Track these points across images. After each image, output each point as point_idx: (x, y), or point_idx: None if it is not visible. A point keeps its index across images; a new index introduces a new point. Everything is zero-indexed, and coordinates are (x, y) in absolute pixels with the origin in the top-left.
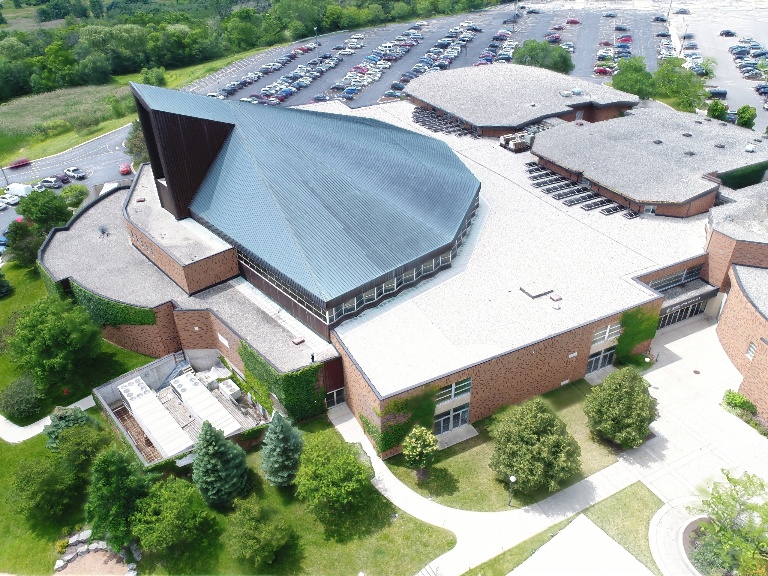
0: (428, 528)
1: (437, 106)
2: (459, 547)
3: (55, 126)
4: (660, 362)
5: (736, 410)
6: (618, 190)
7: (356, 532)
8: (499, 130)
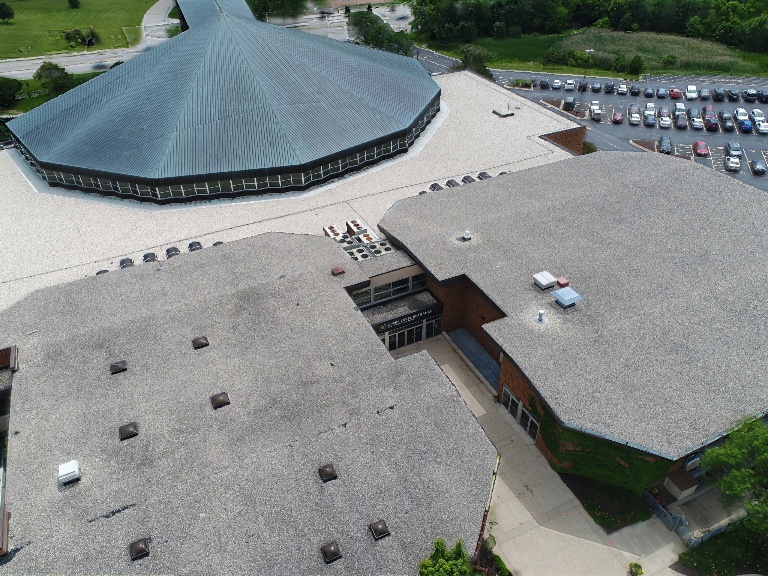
0: None
1: None
2: None
3: (579, 58)
4: None
5: None
6: (81, 279)
7: None
8: None
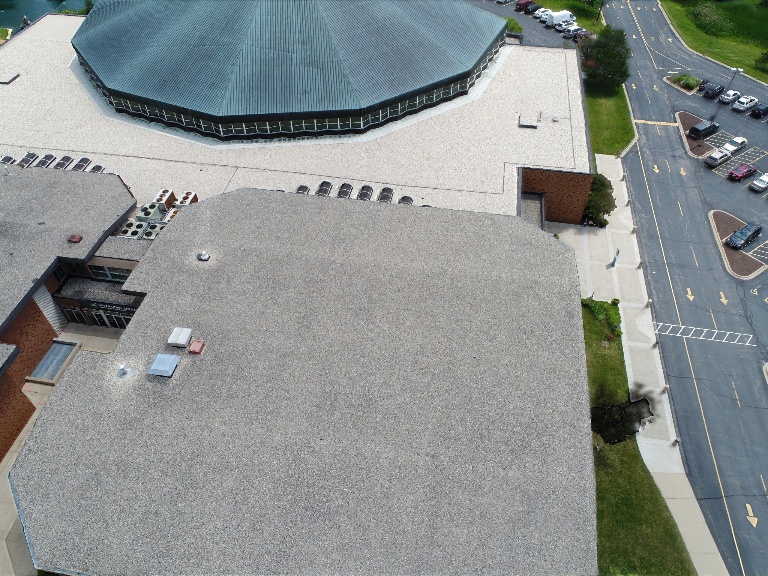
0: None
1: None
2: None
3: None
4: None
5: None
6: None
7: None
8: None
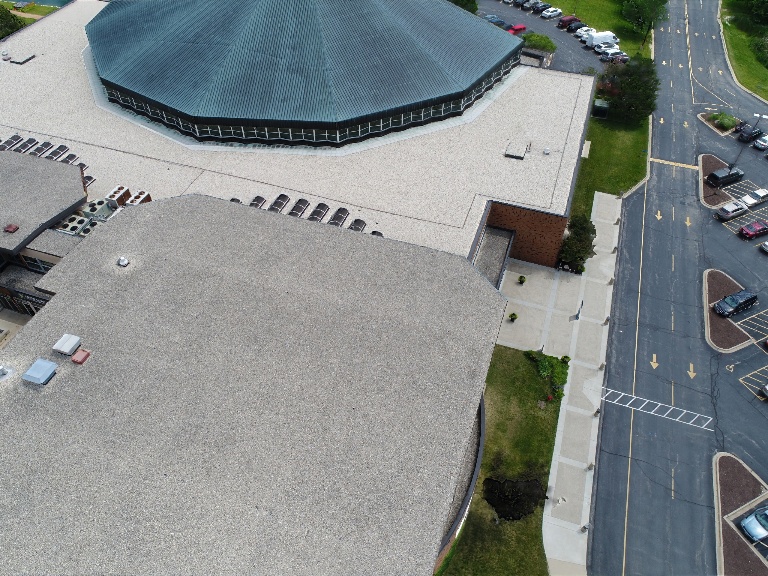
0: None
1: None
2: None
3: None
4: None
5: None
6: None
7: None
8: None
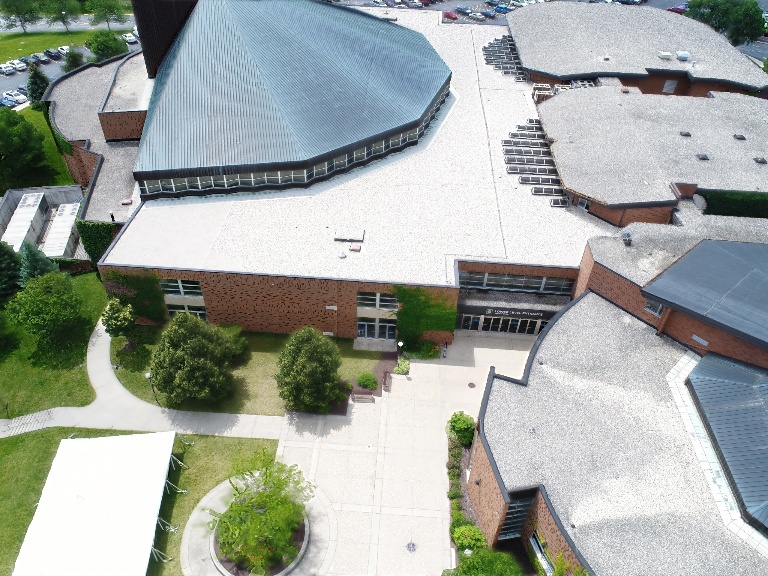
0: (85, 384)
1: (514, 37)
2: (87, 408)
3: None
4: (447, 359)
5: (451, 433)
6: (561, 170)
7: (48, 363)
8: (546, 77)
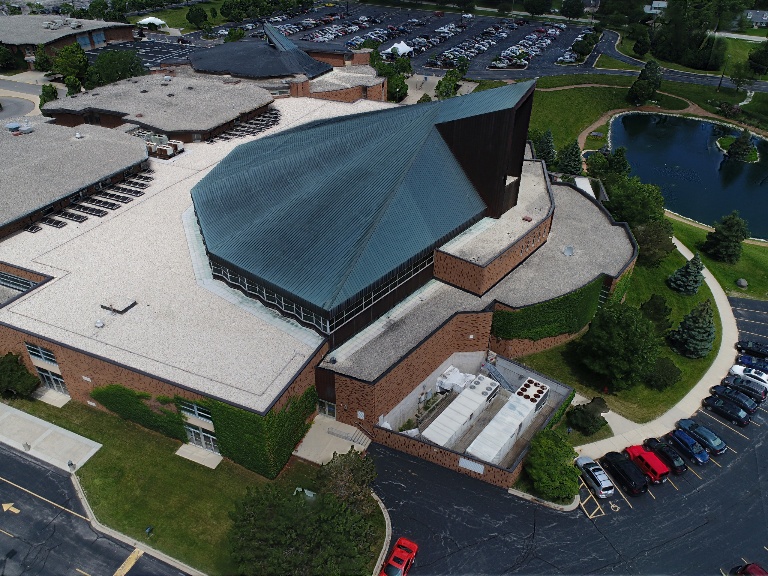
0: None
1: (73, 191)
2: None
3: None
4: None
5: None
6: (264, 103)
7: None
8: None
